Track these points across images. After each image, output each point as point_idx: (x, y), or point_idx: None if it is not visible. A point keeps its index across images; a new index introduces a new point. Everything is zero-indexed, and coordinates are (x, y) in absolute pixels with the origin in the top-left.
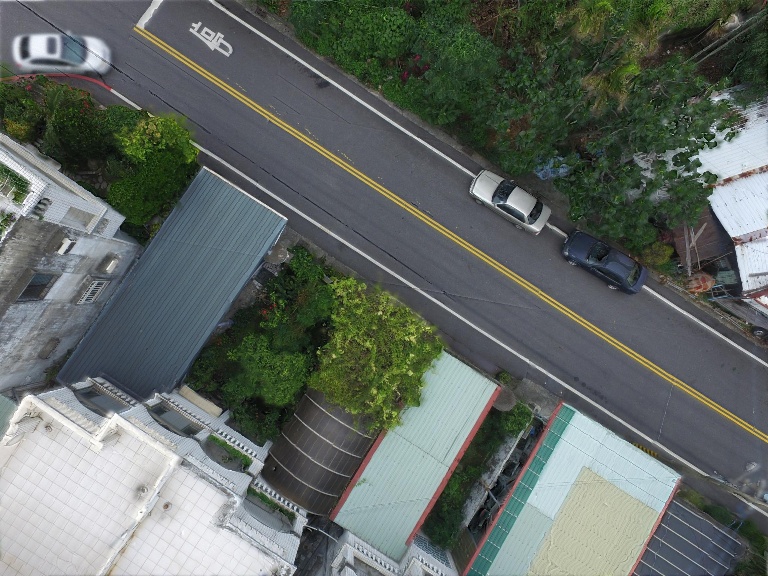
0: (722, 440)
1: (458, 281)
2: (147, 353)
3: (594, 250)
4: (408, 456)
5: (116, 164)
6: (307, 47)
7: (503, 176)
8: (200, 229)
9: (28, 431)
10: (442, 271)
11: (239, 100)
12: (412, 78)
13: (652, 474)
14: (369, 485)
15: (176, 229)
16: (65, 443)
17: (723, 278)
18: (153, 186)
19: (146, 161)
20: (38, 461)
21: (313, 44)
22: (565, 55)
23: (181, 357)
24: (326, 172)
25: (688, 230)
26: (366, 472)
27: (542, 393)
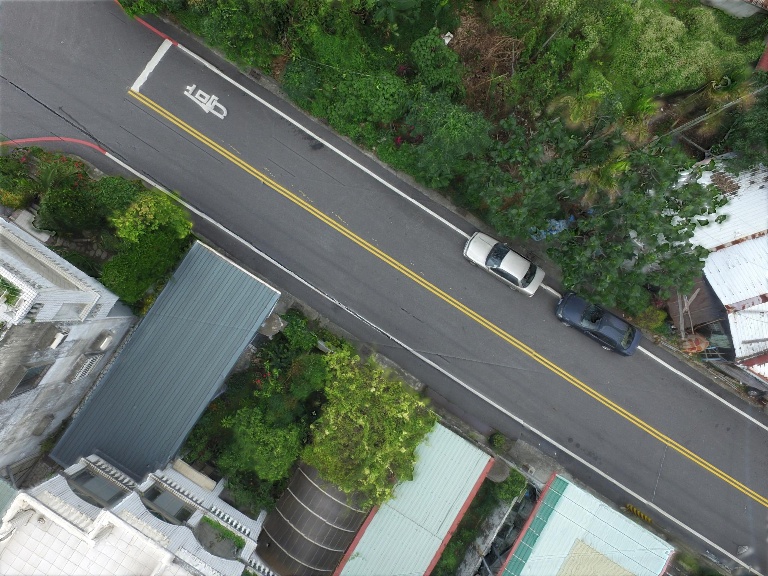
0: (716, 501)
1: (452, 342)
2: (141, 429)
3: (588, 313)
4: (401, 529)
5: (110, 238)
6: (301, 109)
7: (497, 236)
8: (194, 304)
9: (21, 525)
10: (436, 332)
11: (233, 162)
12: (405, 144)
13: (645, 546)
14: (362, 559)
15: (170, 304)
16: (58, 535)
17: (717, 341)
18: (146, 267)
19: (139, 243)
20: (31, 553)
21: (307, 106)
22: (557, 133)
23: (175, 433)
24: (320, 234)
25: (681, 295)
26: (359, 546)
27: (536, 454)
